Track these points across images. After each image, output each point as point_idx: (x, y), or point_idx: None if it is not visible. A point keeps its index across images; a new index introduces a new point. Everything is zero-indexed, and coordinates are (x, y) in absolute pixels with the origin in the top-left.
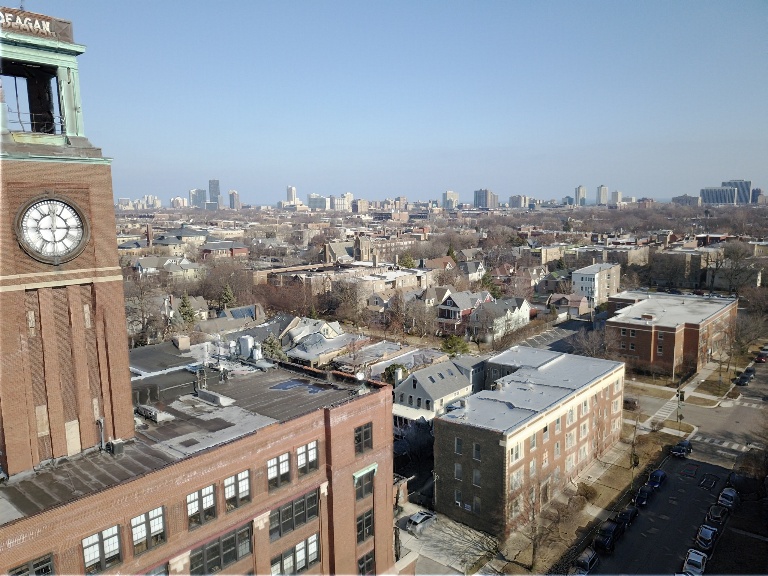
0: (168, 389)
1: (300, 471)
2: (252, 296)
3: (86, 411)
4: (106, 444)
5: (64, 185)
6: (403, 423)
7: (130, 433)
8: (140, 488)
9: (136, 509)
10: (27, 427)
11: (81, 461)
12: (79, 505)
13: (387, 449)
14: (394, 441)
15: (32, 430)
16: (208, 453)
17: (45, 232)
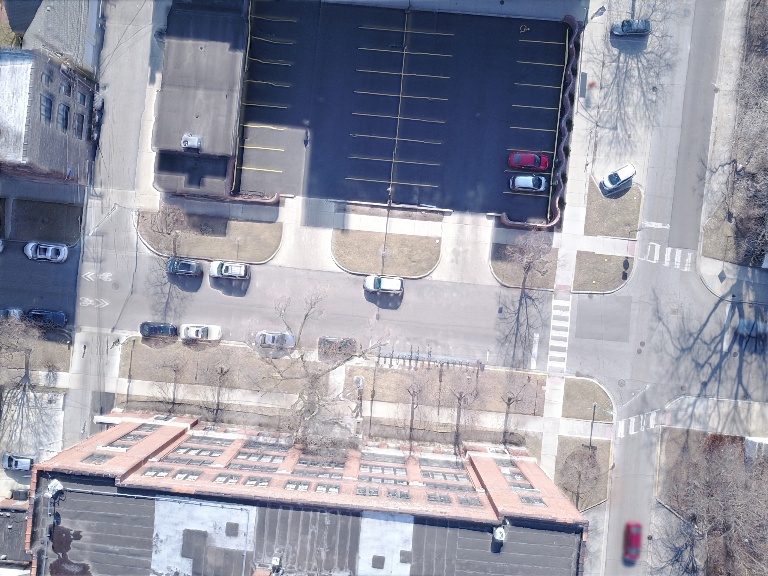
0: None
1: None
2: None
3: None
4: (278, 573)
5: None
6: None
7: (259, 571)
8: None
9: None
10: None
11: (301, 567)
12: None
13: (77, 450)
14: None
15: None
16: None
17: None
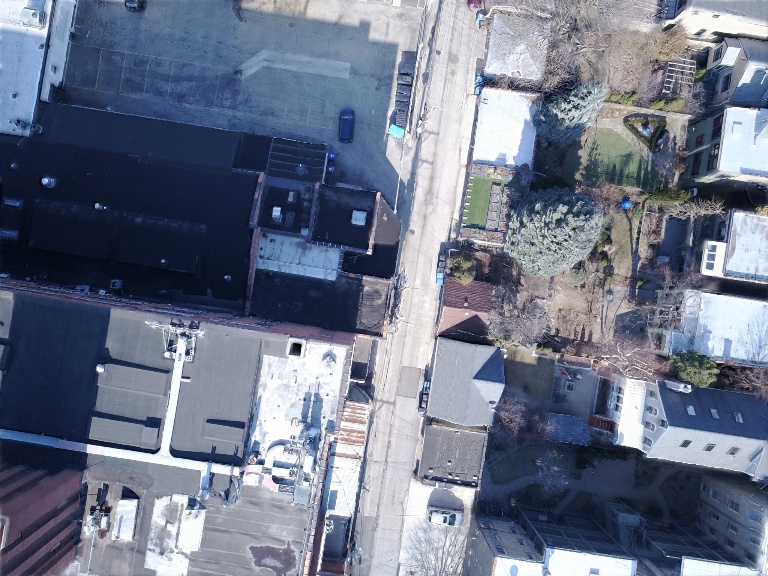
0: None
1: None
2: None
3: None
4: None
5: None
6: (618, 404)
7: None
8: None
9: None
10: None
11: None
12: None
13: None
14: (602, 389)
15: None
16: None
17: None
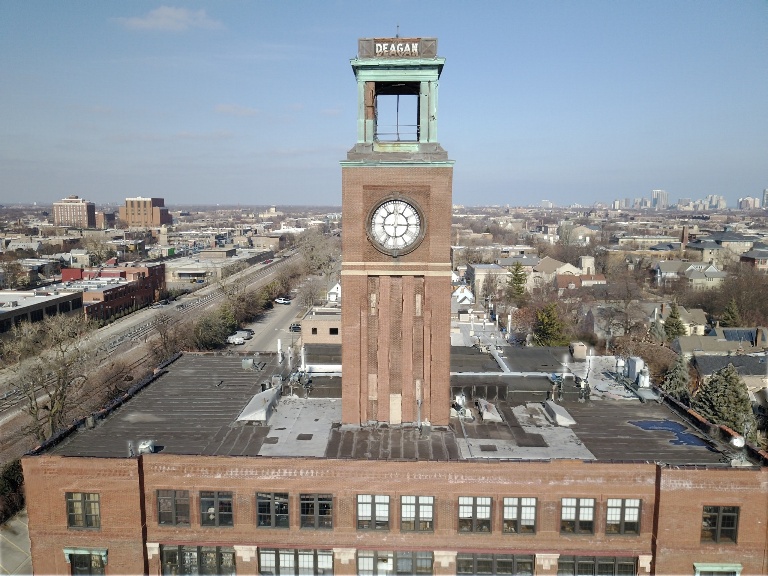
0: (518, 392)
1: (614, 527)
2: (760, 317)
3: (408, 389)
4: None
5: (409, 187)
6: None
7: (444, 420)
8: (412, 471)
9: (407, 489)
10: (358, 388)
11: (397, 431)
12: (357, 464)
13: (767, 554)
14: None
15: (363, 392)
16: (487, 463)
17: (388, 228)
